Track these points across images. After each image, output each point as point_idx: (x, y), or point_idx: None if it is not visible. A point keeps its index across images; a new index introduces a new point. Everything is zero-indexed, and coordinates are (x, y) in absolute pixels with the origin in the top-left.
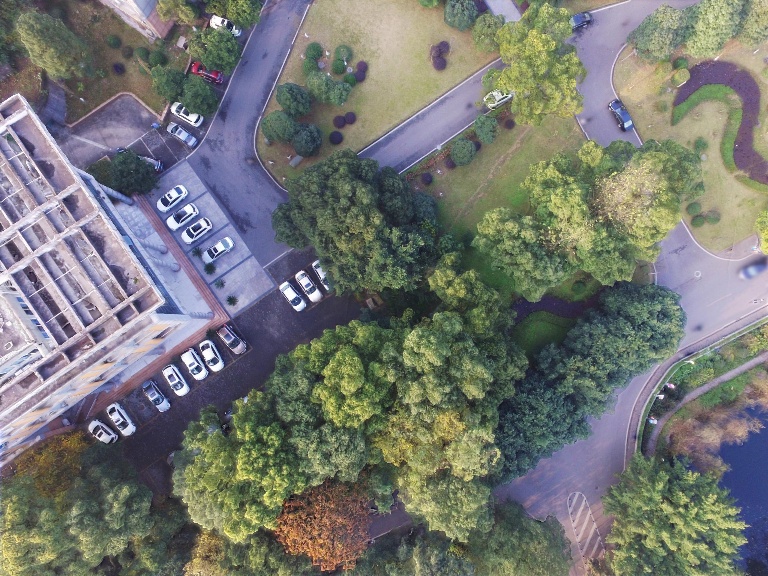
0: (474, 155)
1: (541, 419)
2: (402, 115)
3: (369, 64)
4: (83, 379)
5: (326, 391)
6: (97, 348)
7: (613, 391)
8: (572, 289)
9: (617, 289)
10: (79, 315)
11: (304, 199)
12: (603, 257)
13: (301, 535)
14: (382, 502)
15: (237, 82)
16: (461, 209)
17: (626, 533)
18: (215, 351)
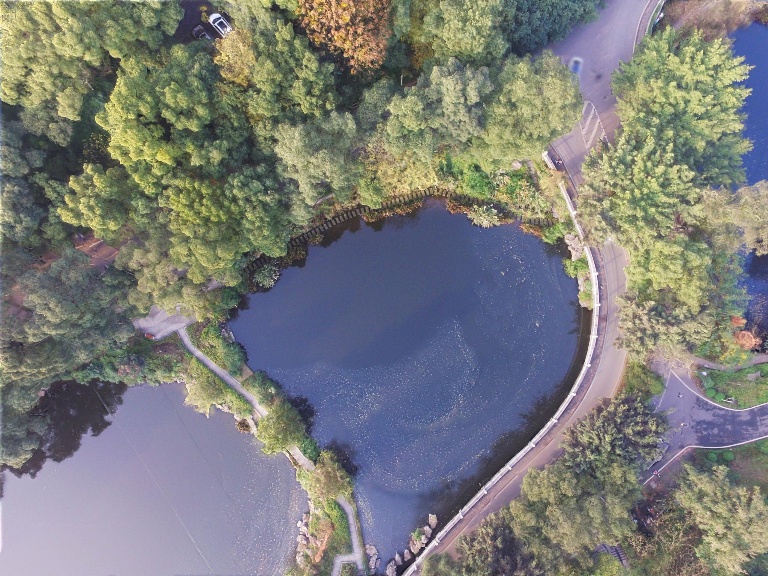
0: None
1: None
2: None
3: None
4: None
5: None
6: None
7: None
8: None
9: None
10: None
11: None
12: None
13: None
14: (401, 3)
15: None
16: None
17: (634, 99)
18: None
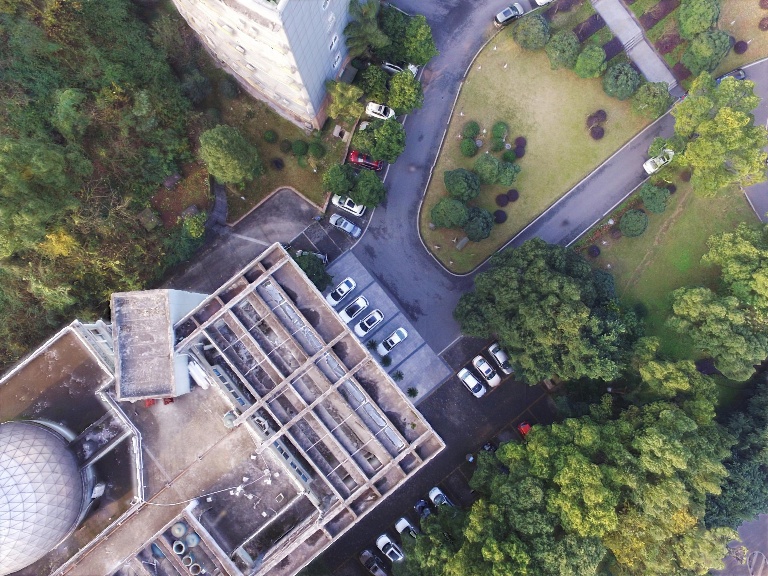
0: (646, 227)
1: (741, 493)
2: (563, 188)
3: (527, 139)
4: None
5: (569, 502)
6: None
7: None
8: None
9: None
10: (359, 466)
11: (502, 295)
12: None
13: None
14: None
15: (395, 167)
16: (629, 279)
17: None
18: None
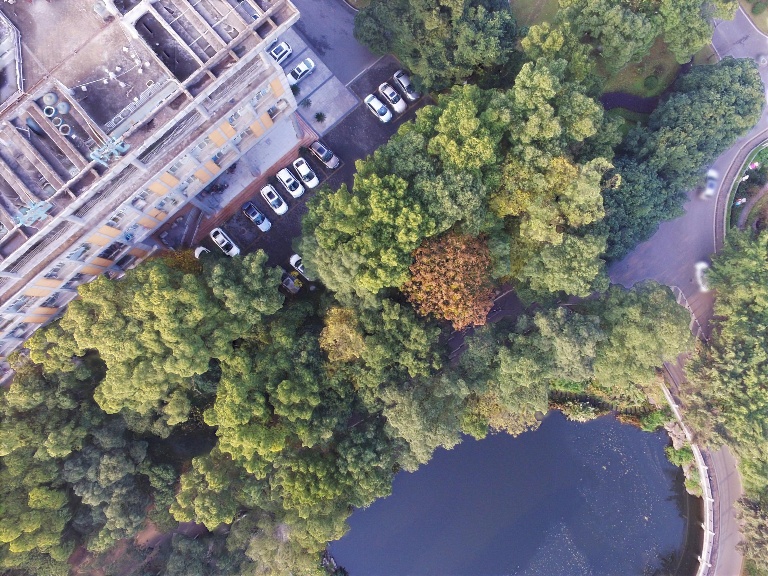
0: None
1: (639, 190)
2: None
3: None
4: (209, 146)
5: (445, 135)
6: (241, 63)
7: (703, 163)
8: (645, 85)
9: (693, 68)
10: None
11: None
12: (685, 14)
13: (435, 280)
14: (503, 260)
15: None
16: (529, 13)
17: (733, 300)
18: (309, 167)
